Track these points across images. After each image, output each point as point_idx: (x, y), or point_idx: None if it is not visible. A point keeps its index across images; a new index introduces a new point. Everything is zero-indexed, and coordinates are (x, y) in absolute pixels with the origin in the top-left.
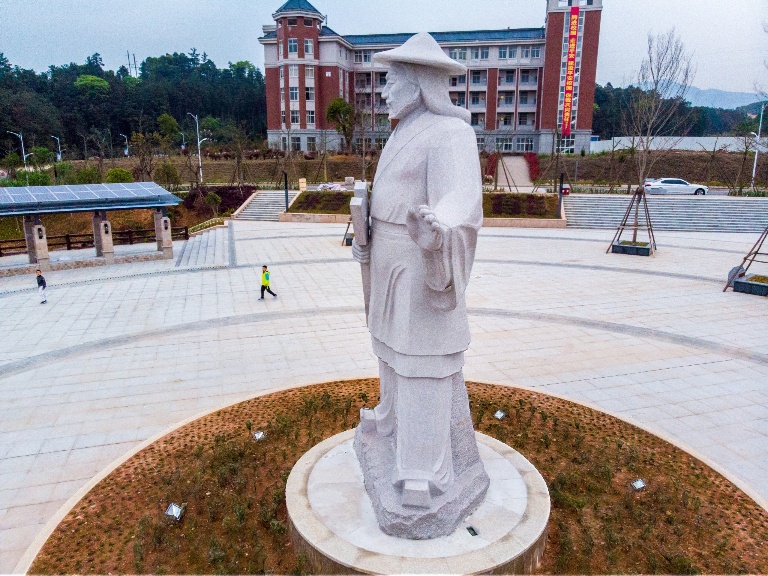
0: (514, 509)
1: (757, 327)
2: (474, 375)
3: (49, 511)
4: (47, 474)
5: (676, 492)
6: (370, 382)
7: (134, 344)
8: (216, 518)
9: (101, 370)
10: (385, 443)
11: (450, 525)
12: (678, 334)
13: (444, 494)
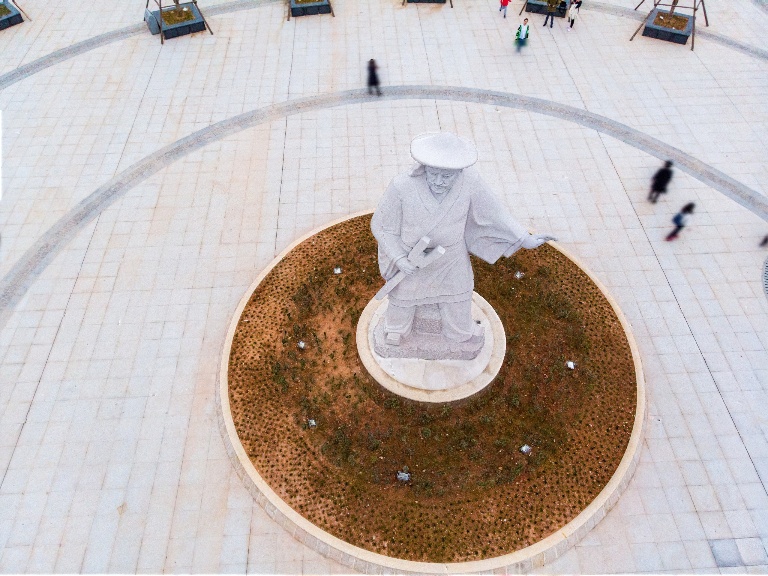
0: None
1: (244, 76)
2: (240, 262)
3: None
4: None
5: None
6: (243, 334)
7: None
8: None
9: None
10: (418, 337)
11: None
12: (231, 118)
13: None
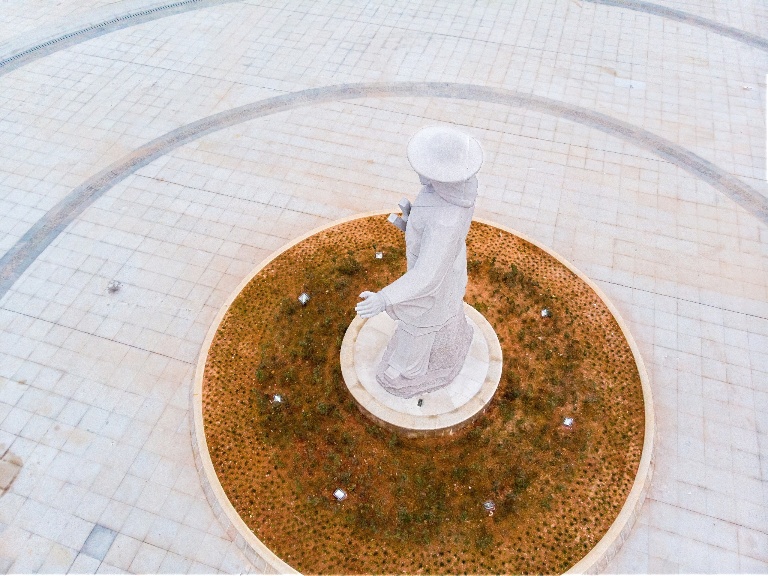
0: (455, 402)
1: None
2: (586, 249)
3: (259, 256)
4: (267, 225)
5: (591, 439)
6: (487, 230)
7: (362, 100)
8: (321, 312)
9: (329, 127)
10: None
11: (408, 395)
12: None
13: (412, 380)
